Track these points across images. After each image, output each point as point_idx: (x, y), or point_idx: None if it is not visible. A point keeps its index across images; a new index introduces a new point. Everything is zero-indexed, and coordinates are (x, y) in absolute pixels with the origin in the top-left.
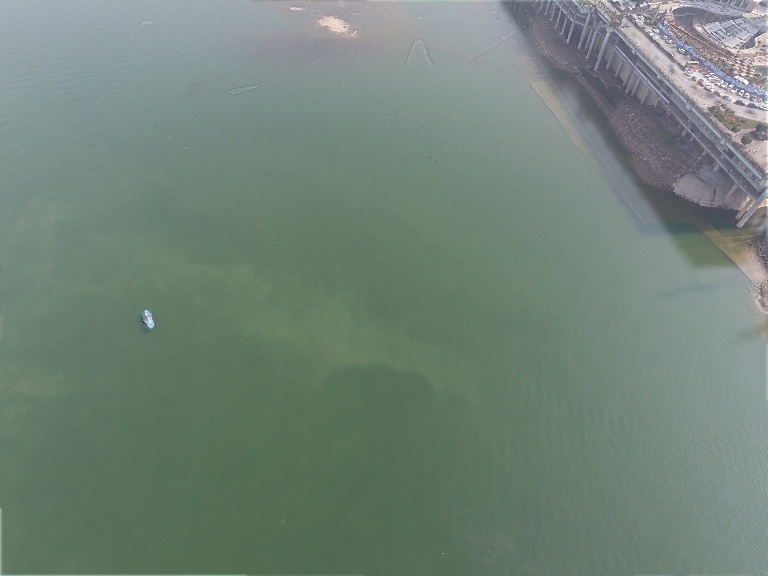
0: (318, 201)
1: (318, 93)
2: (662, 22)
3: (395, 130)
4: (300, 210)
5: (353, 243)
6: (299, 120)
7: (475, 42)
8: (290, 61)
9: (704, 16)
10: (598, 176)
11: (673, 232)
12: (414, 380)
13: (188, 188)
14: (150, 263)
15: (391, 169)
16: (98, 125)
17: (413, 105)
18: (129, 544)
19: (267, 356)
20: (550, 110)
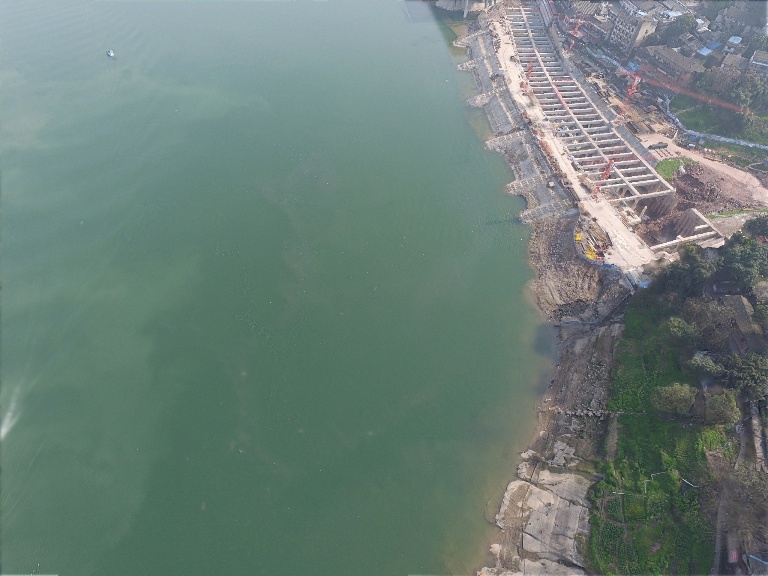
0: (219, 17)
1: None
2: None
3: None
4: (206, 20)
5: None
6: None
7: None
8: None
9: None
10: (394, 1)
11: (425, 21)
12: (253, 70)
13: (137, 8)
14: (112, 35)
15: (267, 2)
16: None
17: None
18: (100, 118)
19: (176, 65)
20: None
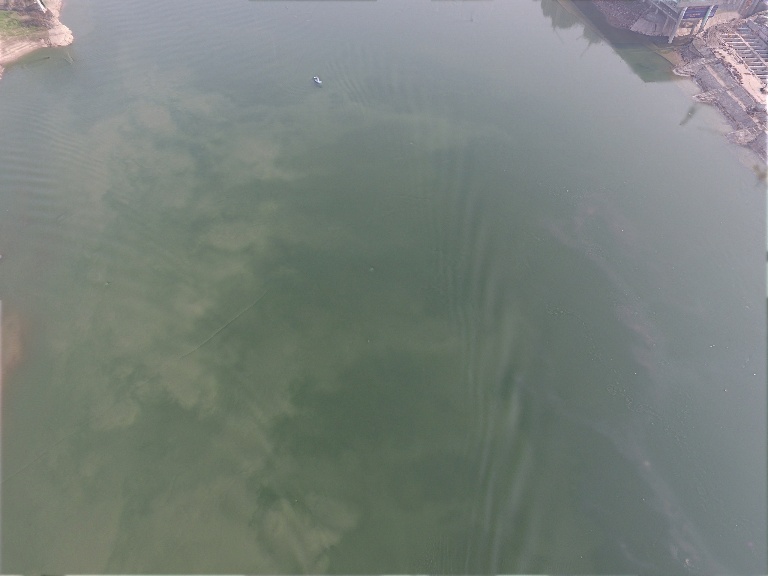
0: (402, 41)
1: None
2: None
3: (447, 6)
4: (391, 44)
5: (428, 57)
6: (379, 7)
7: None
8: None
9: None
10: (582, 25)
11: (628, 46)
12: (473, 100)
13: (320, 32)
14: (310, 60)
15: (447, 25)
16: (252, 5)
17: None
18: (335, 150)
19: (389, 93)
20: None
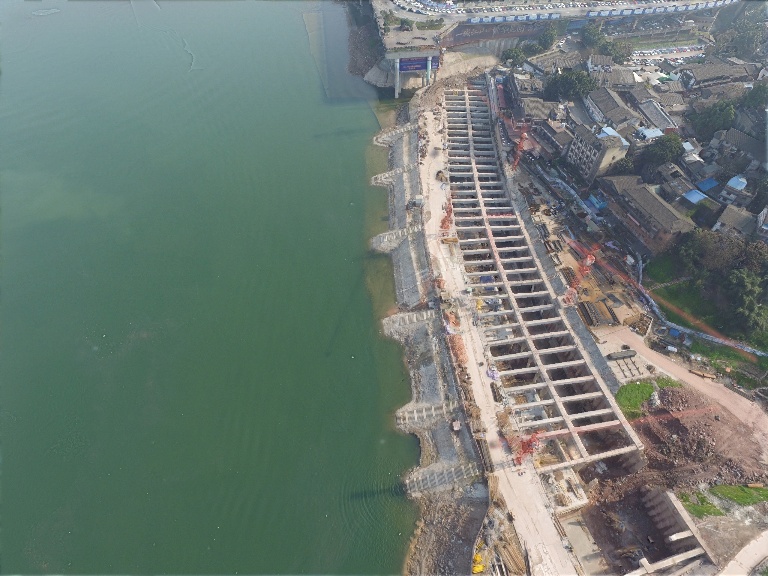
0: (95, 92)
1: (135, 26)
2: None
3: (173, 45)
4: (77, 97)
5: (107, 115)
6: (109, 43)
7: None
8: (116, 2)
9: None
10: (314, 71)
11: (346, 102)
12: (102, 183)
13: None
14: None
15: (160, 71)
16: None
17: (155, 13)
18: None
19: (5, 173)
20: (306, 31)
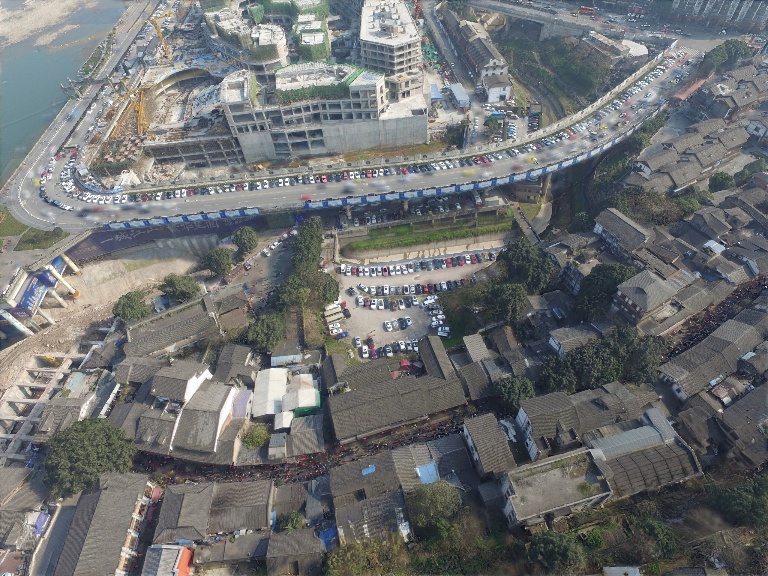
0: None
1: None
2: (120, 92)
3: None
4: None
5: None
6: None
7: (22, 110)
8: None
9: (211, 78)
10: None
11: None
12: None
13: None
14: None
15: None
16: None
17: None
18: None
19: None
20: None
